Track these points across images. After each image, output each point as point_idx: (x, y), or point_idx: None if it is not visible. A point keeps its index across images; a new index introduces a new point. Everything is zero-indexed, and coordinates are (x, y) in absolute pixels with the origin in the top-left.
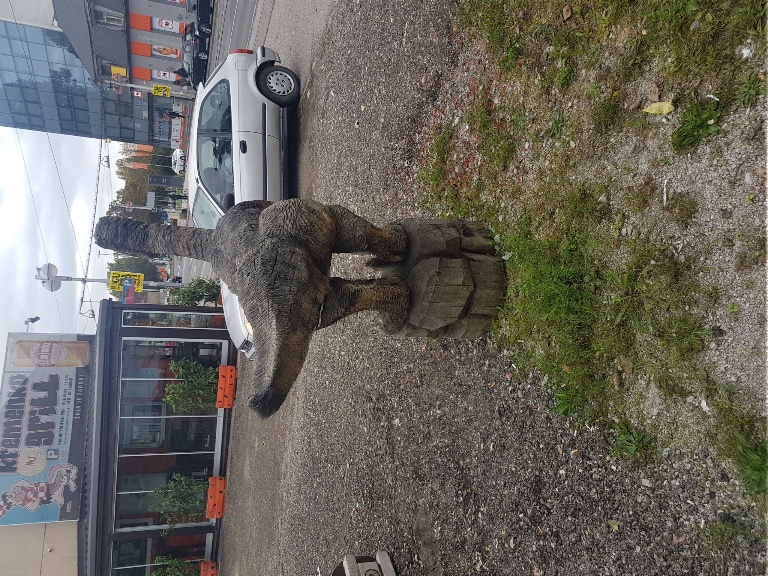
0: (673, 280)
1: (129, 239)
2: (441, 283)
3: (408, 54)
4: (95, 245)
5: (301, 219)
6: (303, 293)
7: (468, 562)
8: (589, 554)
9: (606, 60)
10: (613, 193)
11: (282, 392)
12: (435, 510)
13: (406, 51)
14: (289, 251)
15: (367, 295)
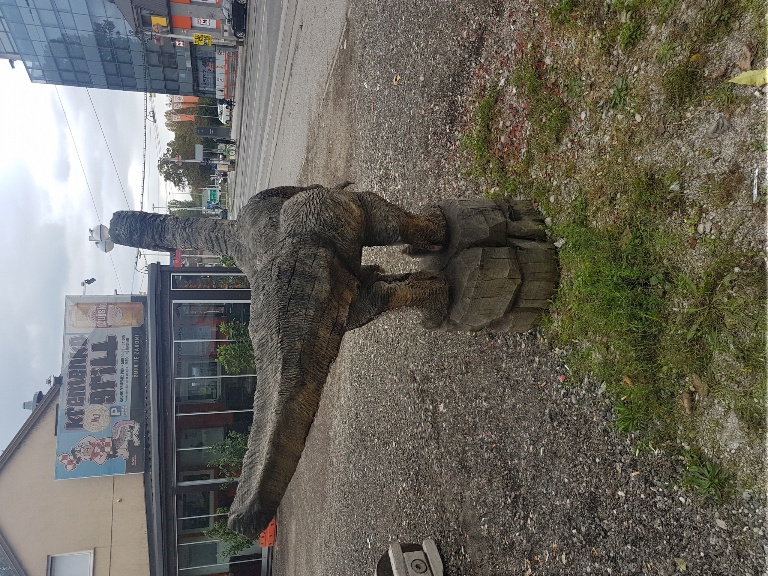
0: (763, 294)
1: (149, 233)
2: (484, 277)
3: (448, 4)
4: None
5: (326, 212)
6: (321, 313)
7: (516, 568)
8: None
9: (682, 15)
10: (688, 180)
11: (274, 490)
12: (482, 506)
13: (446, 1)
14: (311, 253)
15: (401, 292)
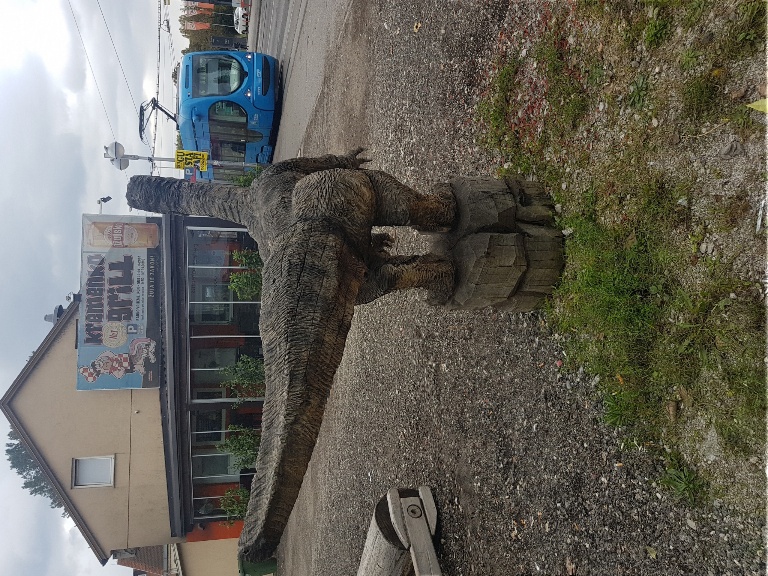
0: (754, 325)
1: (163, 200)
2: (490, 264)
3: None
4: None
5: (337, 197)
6: (328, 317)
7: (504, 526)
8: (623, 569)
9: (709, 23)
10: (696, 197)
11: (277, 526)
12: (476, 465)
13: None
14: (321, 243)
15: (408, 275)
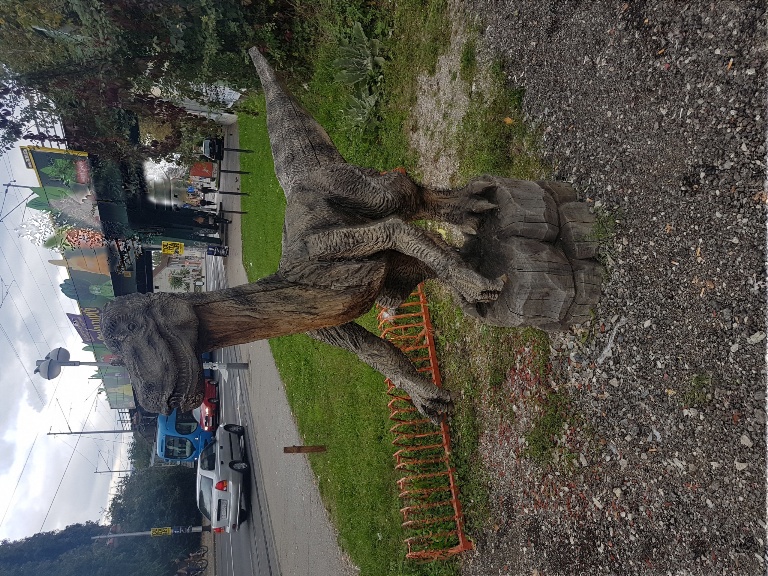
0: (461, 149)
1: None
2: None
3: None
4: (111, 310)
5: None
6: None
7: None
8: None
9: None
10: None
11: None
12: None
13: None
14: None
15: None
